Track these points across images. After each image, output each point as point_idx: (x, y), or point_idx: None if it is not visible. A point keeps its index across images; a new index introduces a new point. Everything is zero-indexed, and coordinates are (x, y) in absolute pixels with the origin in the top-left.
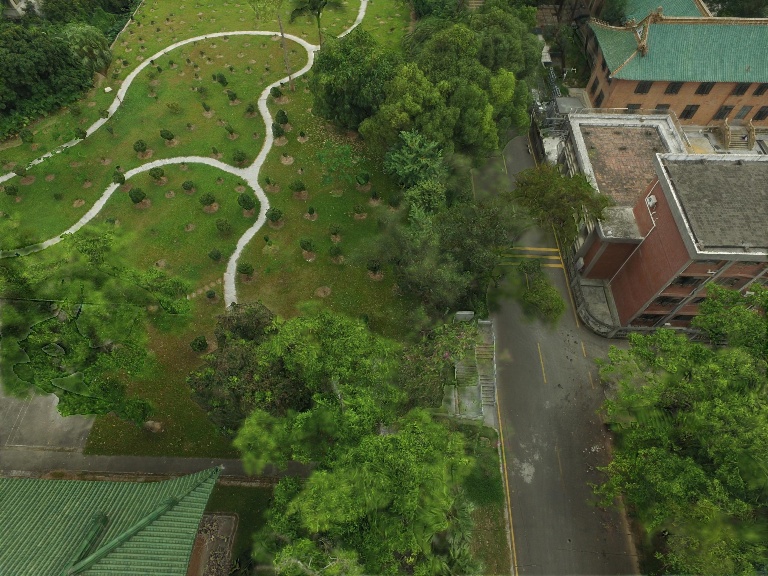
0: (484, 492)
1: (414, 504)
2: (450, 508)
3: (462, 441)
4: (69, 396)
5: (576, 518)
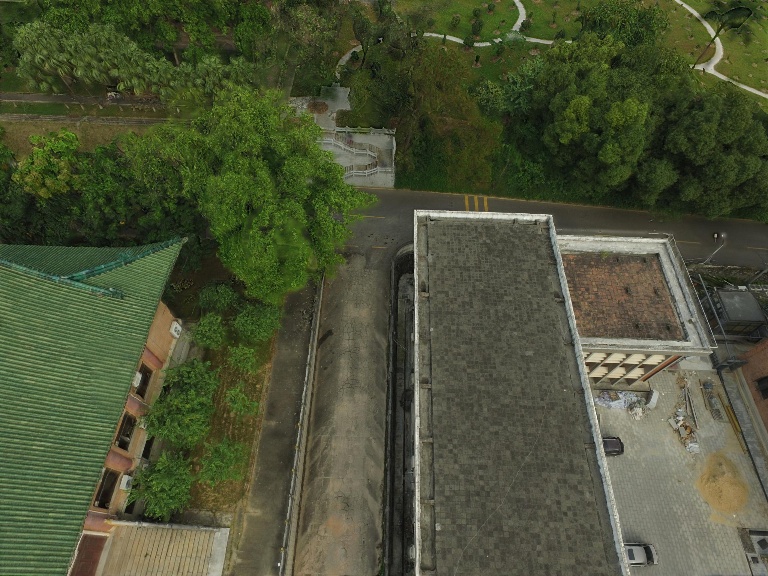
0: None
1: None
2: (241, 66)
3: None
4: None
5: (251, 214)
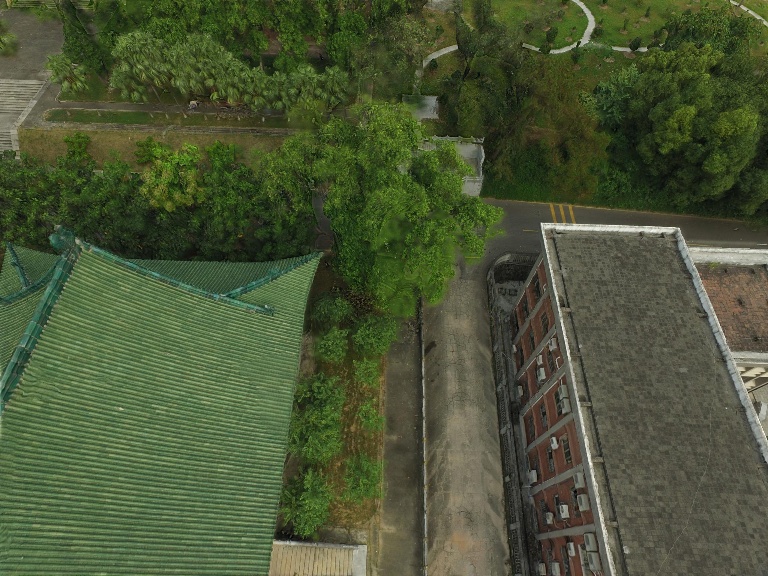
0: None
1: None
2: (336, 76)
3: None
4: None
5: None
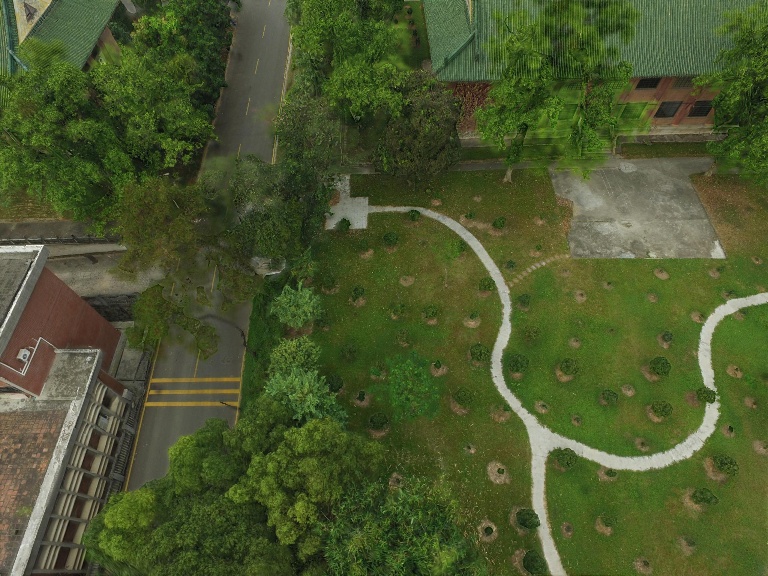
0: None
1: None
2: None
3: None
4: None
5: None
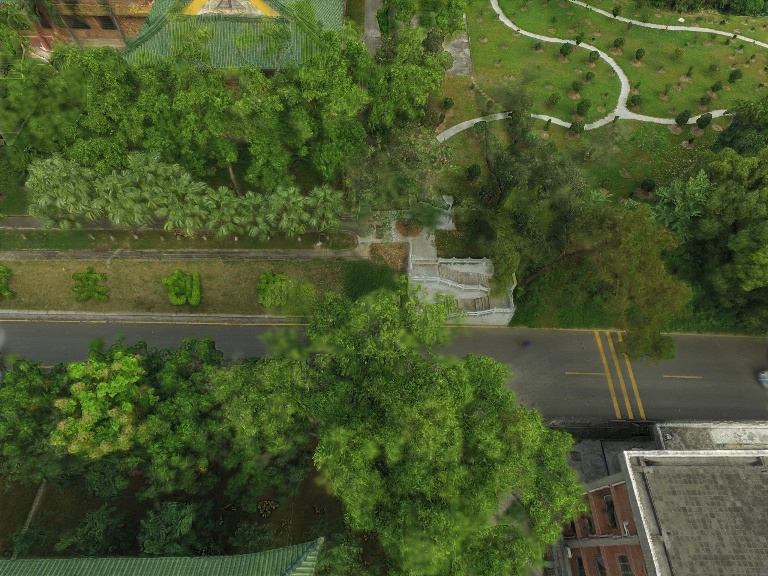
0: (355, 290)
1: (311, 94)
2: (328, 198)
3: (371, 194)
4: (385, 8)
5: None
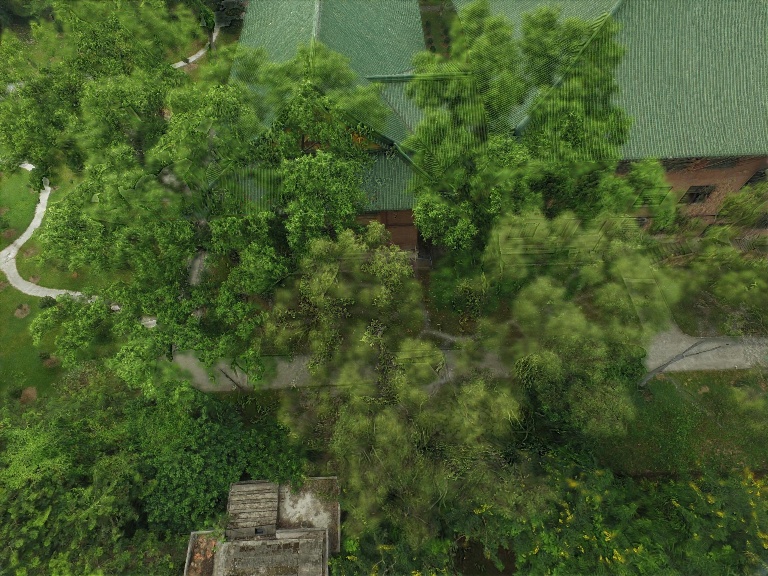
0: None
1: None
2: None
3: None
4: None
5: None
